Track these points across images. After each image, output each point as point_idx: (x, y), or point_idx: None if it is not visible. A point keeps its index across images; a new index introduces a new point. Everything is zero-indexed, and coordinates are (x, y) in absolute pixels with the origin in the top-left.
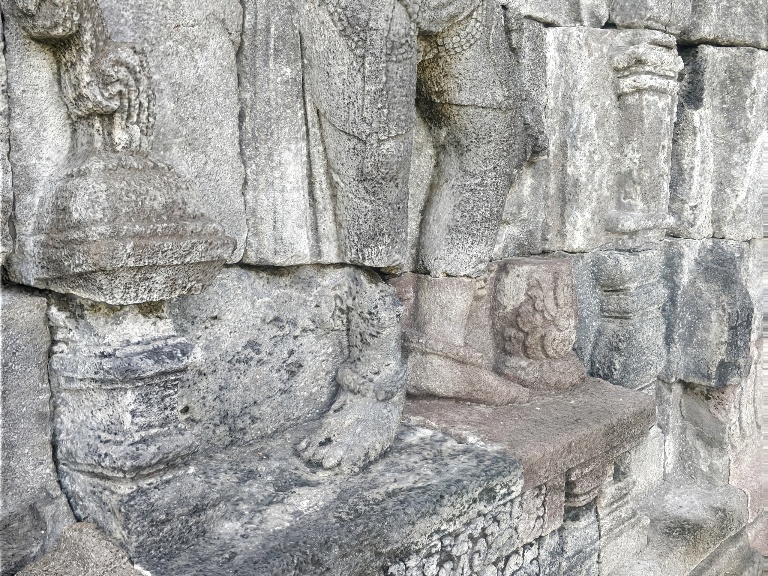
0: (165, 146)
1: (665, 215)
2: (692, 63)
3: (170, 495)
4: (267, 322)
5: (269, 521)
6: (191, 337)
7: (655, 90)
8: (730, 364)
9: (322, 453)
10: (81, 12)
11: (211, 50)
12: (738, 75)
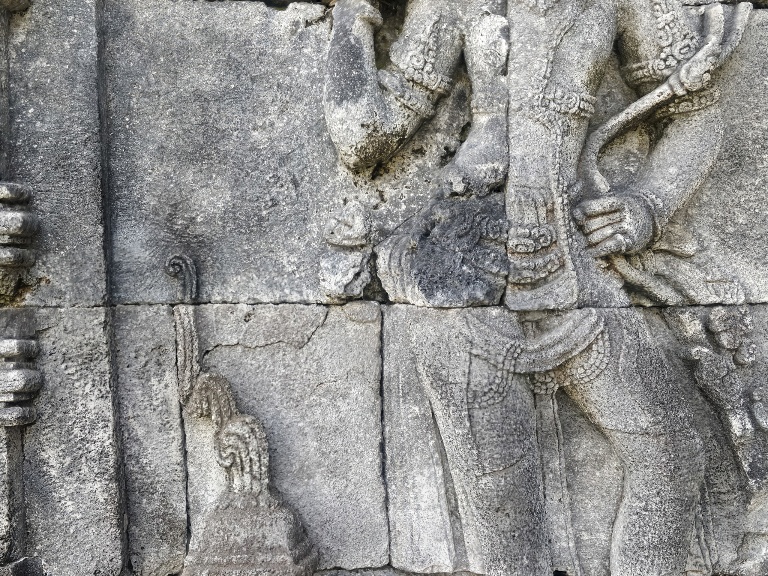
0: (309, 475)
1: None
2: None
3: None
4: None
5: None
6: None
7: None
8: None
9: None
10: (210, 401)
11: (353, 397)
12: None
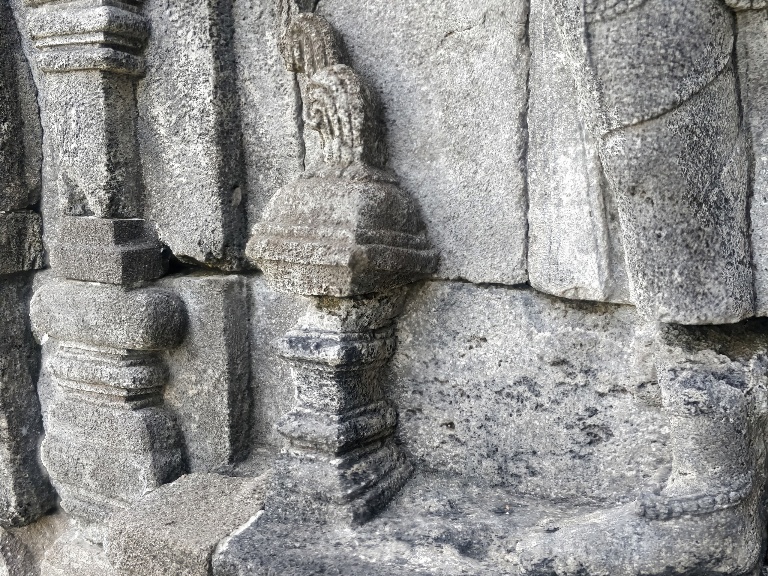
0: (433, 156)
1: None
2: None
3: (304, 472)
4: (550, 362)
5: (372, 549)
6: (452, 352)
7: None
8: None
9: (528, 535)
10: (303, 48)
11: (491, 49)
12: None
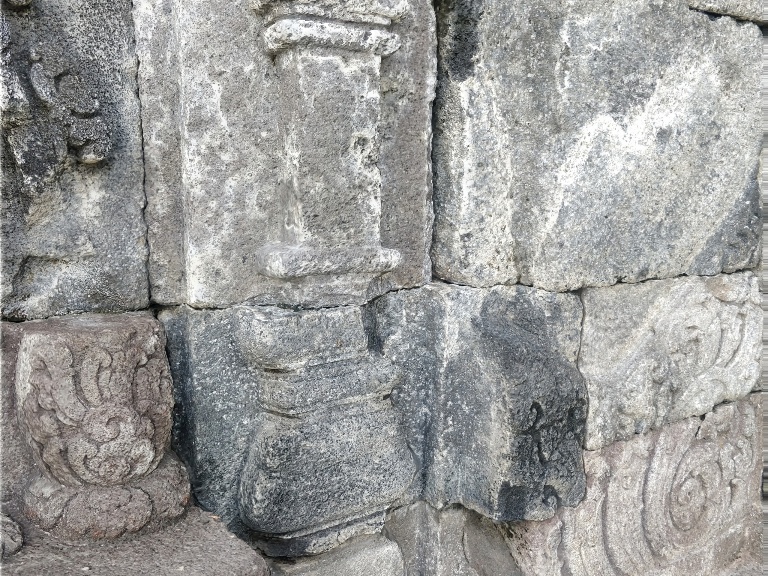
0: None
1: (375, 250)
2: (458, 6)
3: None
4: None
5: None
6: None
7: (328, 45)
8: (526, 488)
9: None
10: None
11: None
12: (544, 24)
